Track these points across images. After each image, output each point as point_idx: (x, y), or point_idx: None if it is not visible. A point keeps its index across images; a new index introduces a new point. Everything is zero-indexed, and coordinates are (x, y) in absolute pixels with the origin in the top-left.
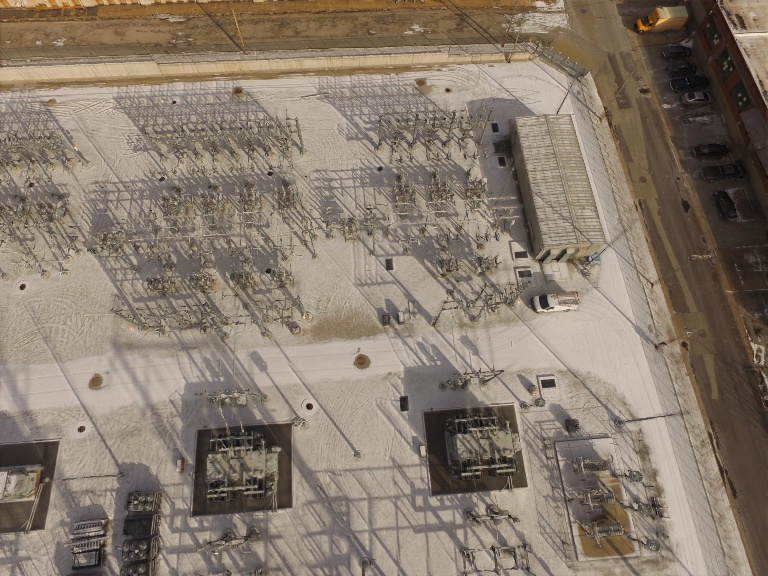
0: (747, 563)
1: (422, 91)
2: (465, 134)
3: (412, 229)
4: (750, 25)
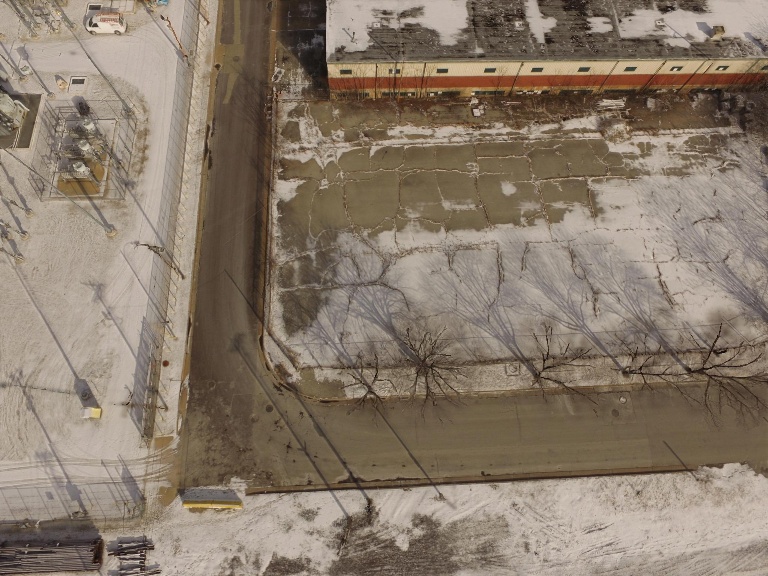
0: (196, 210)
1: None
2: None
3: None
4: None
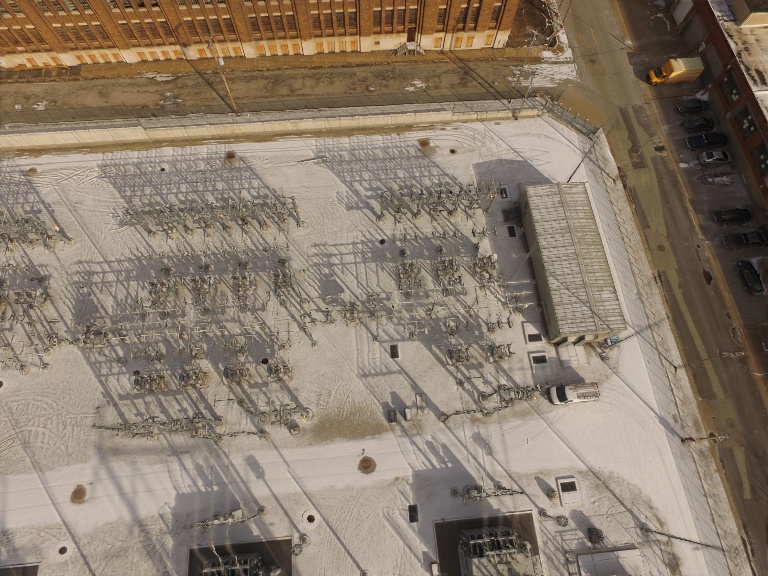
0: None
1: (425, 153)
2: (472, 203)
3: (418, 310)
4: None
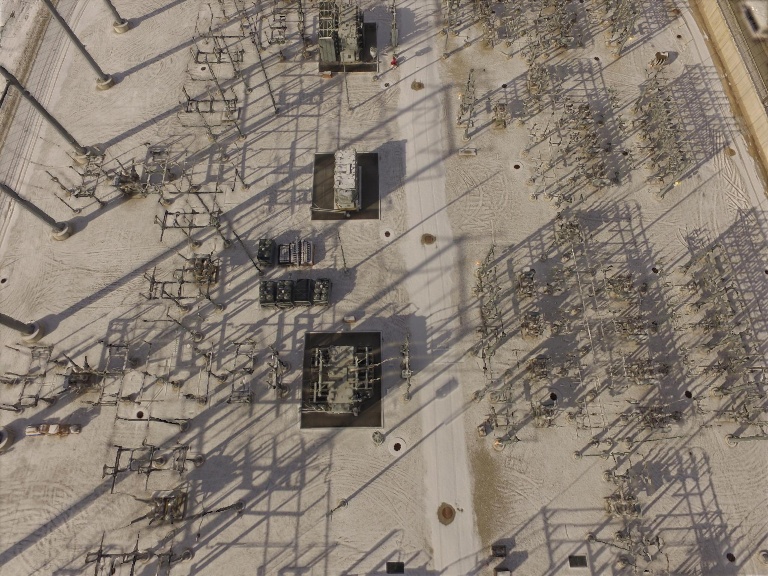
0: None
1: None
2: None
3: None
4: None
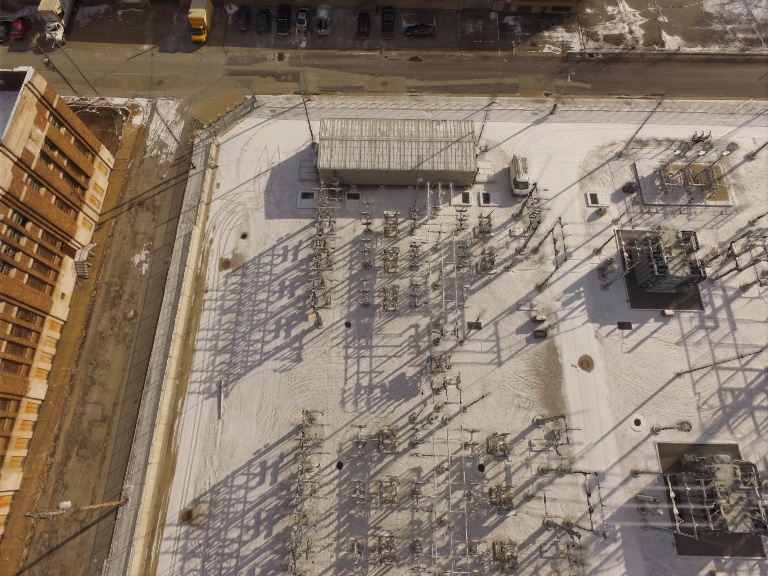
0: (708, 101)
1: (239, 265)
2: None
3: (432, 297)
4: None
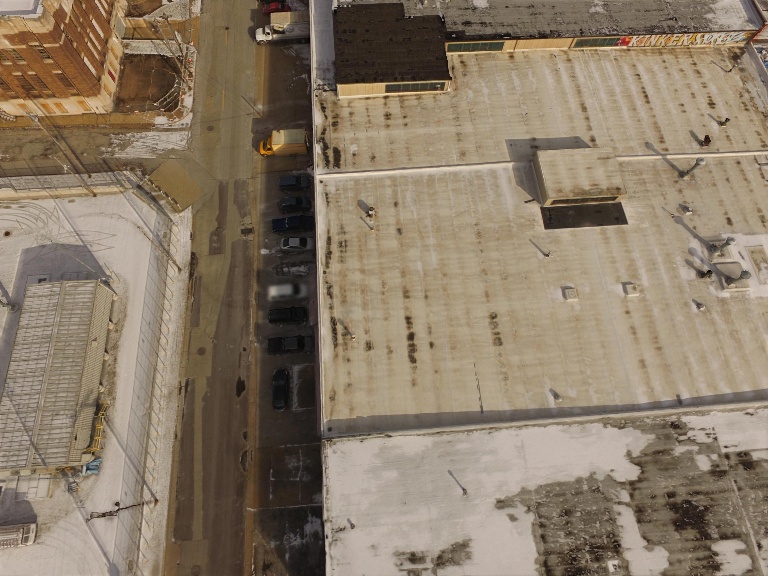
0: None
1: None
2: None
3: None
4: (346, 162)
